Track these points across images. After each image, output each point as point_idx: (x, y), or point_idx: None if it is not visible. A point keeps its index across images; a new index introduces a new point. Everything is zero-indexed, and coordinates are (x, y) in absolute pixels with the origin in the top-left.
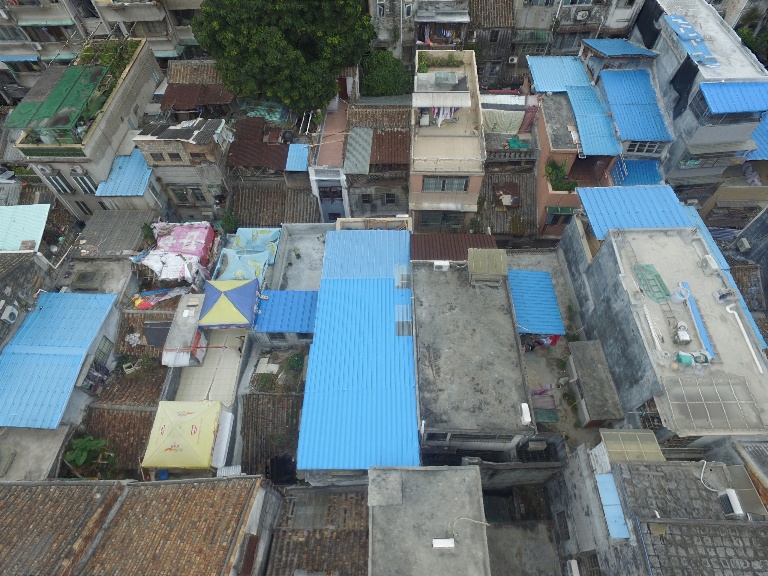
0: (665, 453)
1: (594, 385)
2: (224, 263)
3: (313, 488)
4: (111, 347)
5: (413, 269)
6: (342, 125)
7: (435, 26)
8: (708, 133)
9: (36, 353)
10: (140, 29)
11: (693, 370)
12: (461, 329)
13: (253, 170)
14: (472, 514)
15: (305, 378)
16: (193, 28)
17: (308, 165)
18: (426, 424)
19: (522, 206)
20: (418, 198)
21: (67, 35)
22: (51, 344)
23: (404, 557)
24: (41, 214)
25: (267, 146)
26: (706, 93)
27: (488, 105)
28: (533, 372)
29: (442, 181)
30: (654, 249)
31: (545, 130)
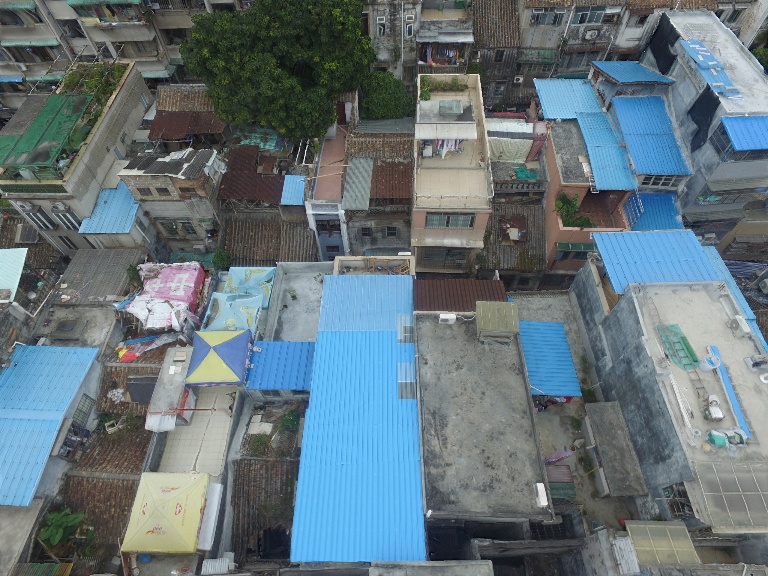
0: (695, 541)
1: (614, 455)
2: (215, 304)
3: (309, 571)
4: (92, 404)
5: (417, 322)
6: (340, 153)
7: (438, 46)
8: (730, 169)
9: (9, 418)
10: (129, 49)
11: (727, 452)
12: (469, 392)
13: (246, 203)
14: None
15: (300, 444)
16: (182, 55)
17: (304, 199)
18: (432, 505)
19: (530, 240)
20: (421, 234)
21: (53, 55)
22: (25, 407)
23: None
24: (18, 259)
25: (261, 178)
26: (729, 128)
27: (494, 133)
28: (546, 432)
29: (446, 217)
30: (678, 306)
31: (555, 161)
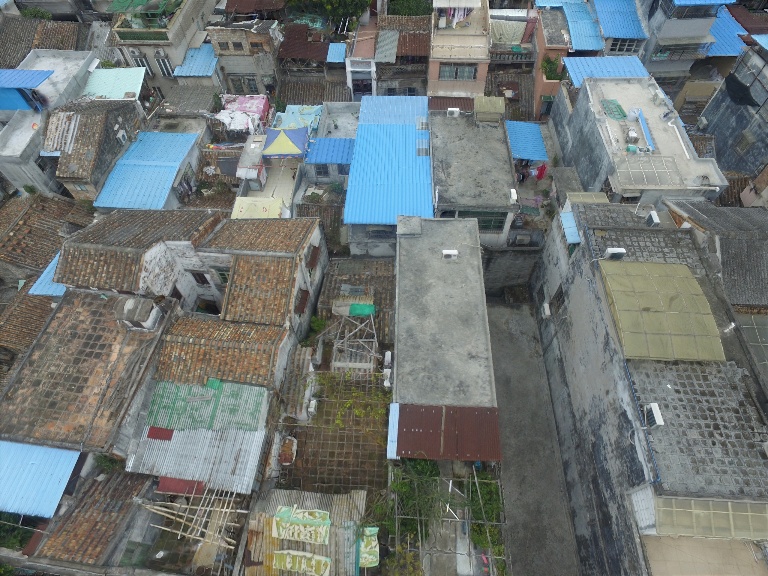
0: None
1: None
2: None
3: (352, 258)
4: (193, 175)
5: (431, 116)
6: (372, 33)
7: None
8: (674, 27)
9: (142, 164)
10: None
11: None
12: (467, 151)
13: (299, 63)
14: (471, 243)
15: (346, 188)
16: None
17: None
18: None
19: (522, 100)
20: (435, 86)
21: None
22: (152, 160)
23: (422, 264)
24: (139, 74)
25: (311, 44)
26: None
27: (496, 16)
28: None
29: (455, 69)
30: (618, 91)
31: (542, 33)
